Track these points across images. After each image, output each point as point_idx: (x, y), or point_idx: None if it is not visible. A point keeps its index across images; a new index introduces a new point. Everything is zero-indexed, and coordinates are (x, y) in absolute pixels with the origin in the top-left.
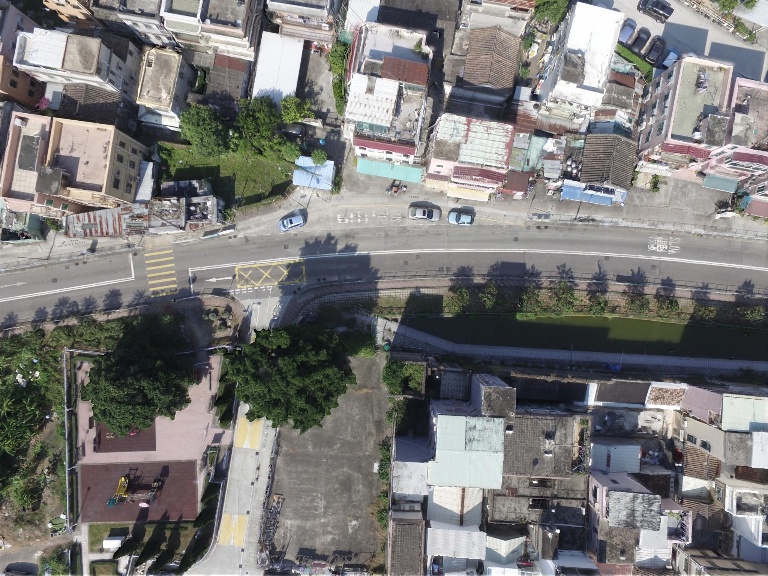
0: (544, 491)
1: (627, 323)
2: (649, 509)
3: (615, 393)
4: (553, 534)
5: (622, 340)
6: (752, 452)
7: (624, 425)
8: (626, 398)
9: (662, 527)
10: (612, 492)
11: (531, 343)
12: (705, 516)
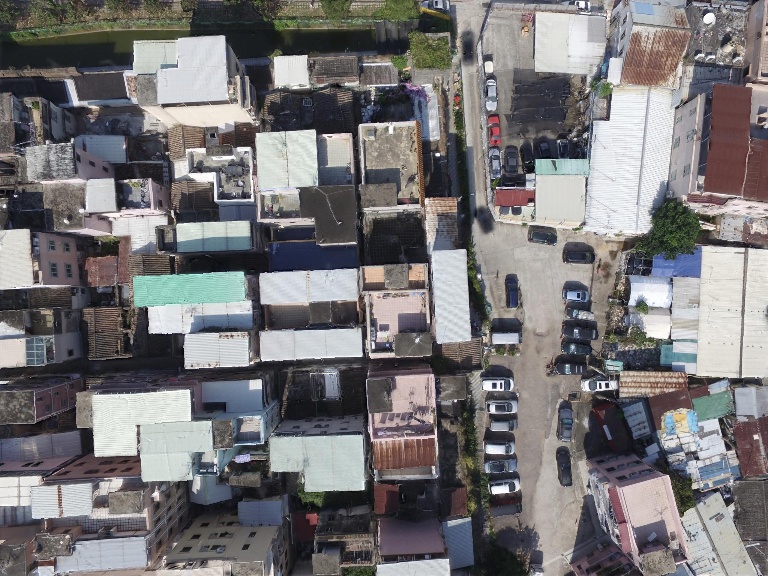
0: (8, 179)
1: (132, 35)
2: (63, 157)
3: (95, 88)
4: (1, 210)
5: (129, 53)
6: (157, 89)
7: (130, 131)
8: (108, 93)
9: (109, 190)
10: (28, 147)
11: (36, 65)
12: (186, 193)
